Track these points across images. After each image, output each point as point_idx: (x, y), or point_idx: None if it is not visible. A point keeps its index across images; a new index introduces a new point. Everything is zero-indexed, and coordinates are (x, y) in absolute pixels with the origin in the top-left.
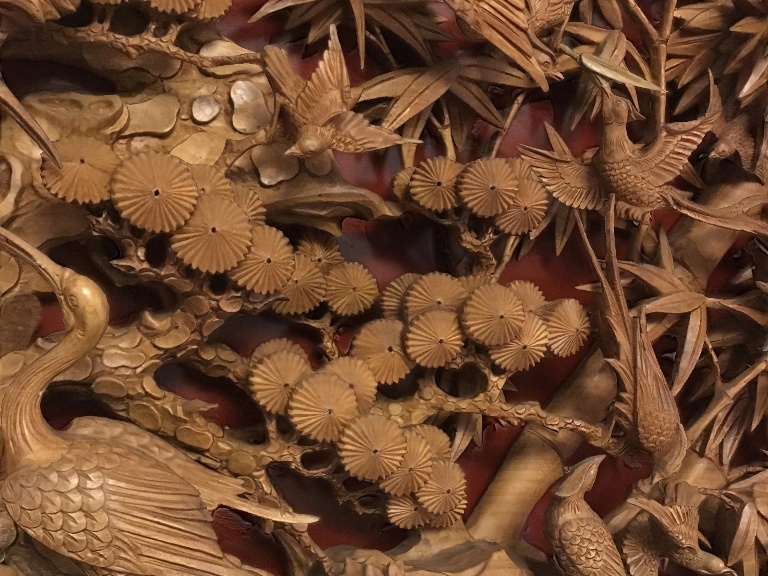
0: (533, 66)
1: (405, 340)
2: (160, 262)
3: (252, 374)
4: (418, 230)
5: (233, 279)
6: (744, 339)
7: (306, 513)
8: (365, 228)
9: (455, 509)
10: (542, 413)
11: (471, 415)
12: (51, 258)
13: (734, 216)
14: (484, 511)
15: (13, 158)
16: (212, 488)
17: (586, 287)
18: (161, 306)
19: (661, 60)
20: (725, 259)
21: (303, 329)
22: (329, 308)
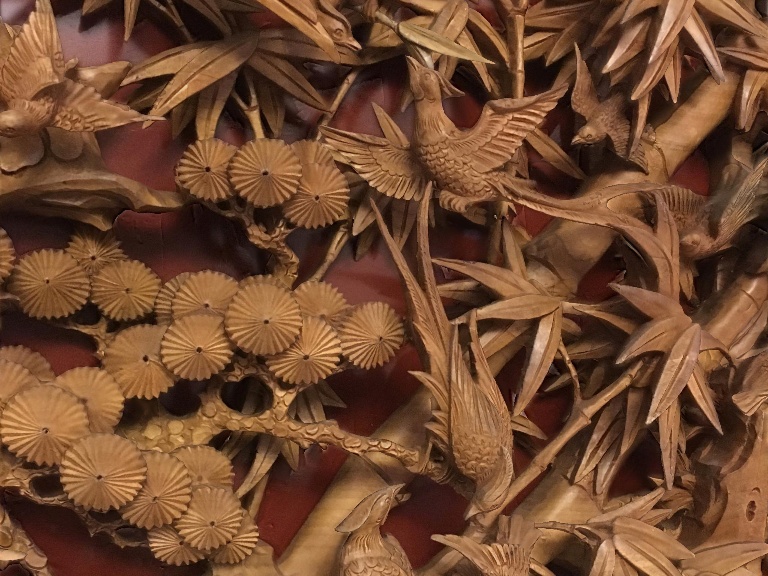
0: (319, 33)
1: None
2: None
3: None
4: (206, 224)
5: None
6: (614, 350)
7: (51, 546)
8: (162, 223)
9: (242, 543)
10: (339, 434)
11: None
12: None
13: (588, 208)
14: (298, 544)
15: None
16: None
17: None
18: None
19: (517, 33)
20: (604, 259)
21: (71, 335)
22: (100, 312)
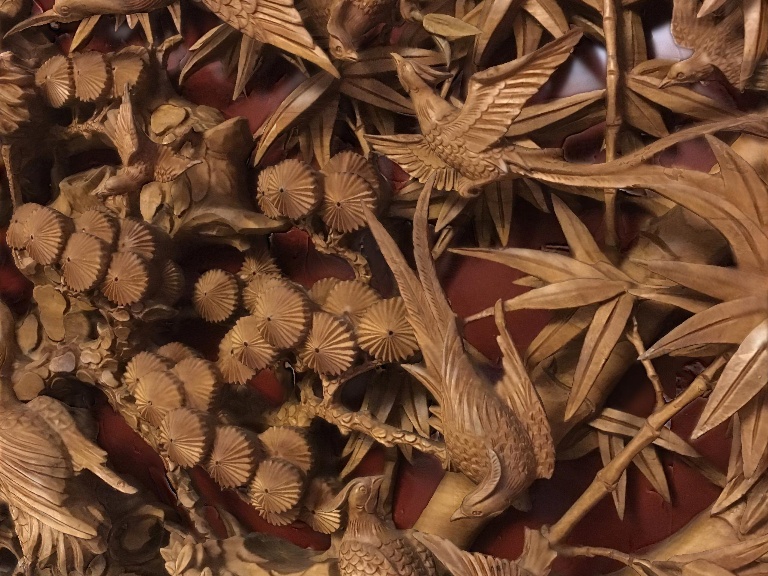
0: (318, 56)
1: None
2: None
3: (126, 370)
4: (308, 237)
5: (104, 295)
6: None
7: (205, 494)
8: None
9: (326, 516)
10: (367, 423)
11: None
12: None
13: (625, 168)
14: None
15: None
16: (84, 455)
17: (522, 281)
18: None
19: None
20: None
21: None
22: None
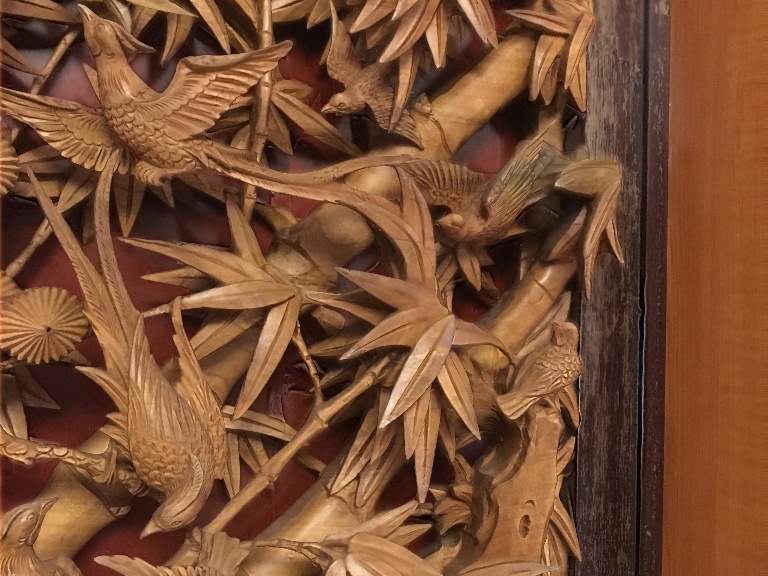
0: None
1: None
2: None
3: None
4: None
5: None
6: None
7: None
8: None
9: None
10: None
11: None
12: None
13: (319, 183)
14: None
15: None
16: None
17: (154, 277)
18: None
19: None
20: (375, 244)
21: None
22: None
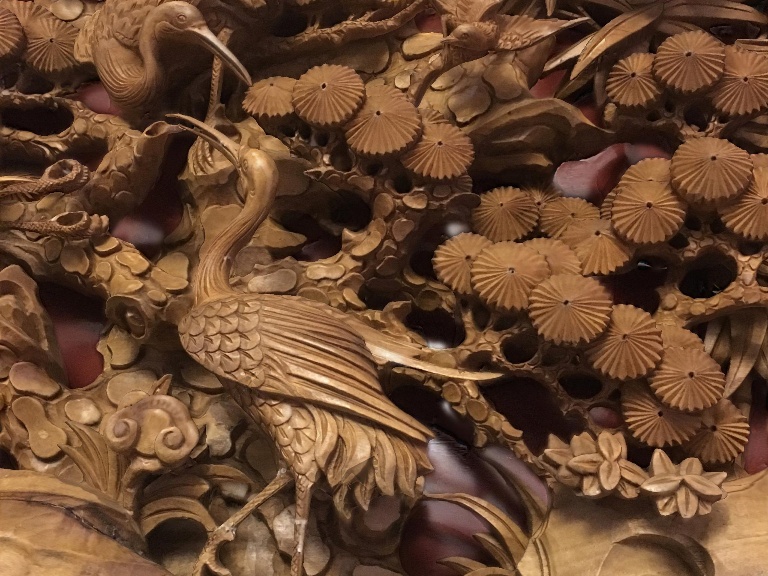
0: None
1: (611, 218)
2: (346, 168)
3: (435, 255)
4: (640, 151)
5: (409, 167)
6: None
7: (525, 428)
8: (598, 185)
9: (731, 433)
10: None
11: (748, 340)
12: (283, 223)
13: None
14: None
15: (243, 130)
16: (385, 347)
17: None
18: (360, 226)
19: None
20: None
21: None
22: None
